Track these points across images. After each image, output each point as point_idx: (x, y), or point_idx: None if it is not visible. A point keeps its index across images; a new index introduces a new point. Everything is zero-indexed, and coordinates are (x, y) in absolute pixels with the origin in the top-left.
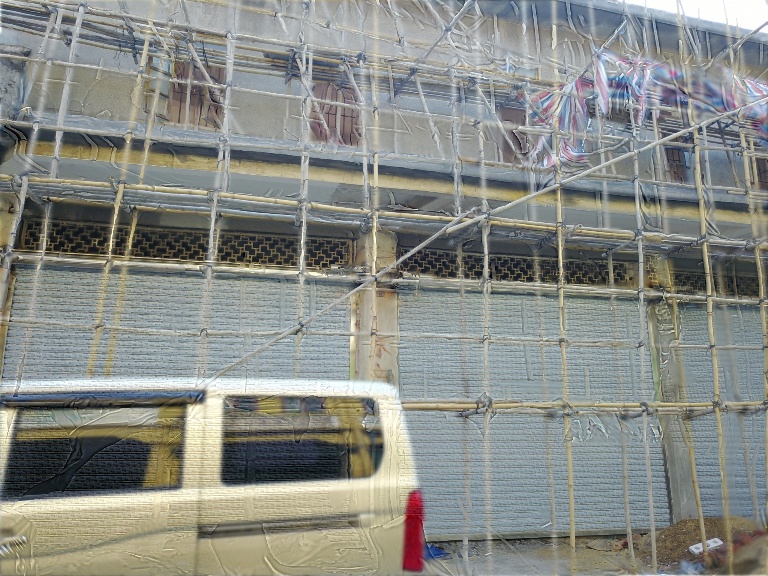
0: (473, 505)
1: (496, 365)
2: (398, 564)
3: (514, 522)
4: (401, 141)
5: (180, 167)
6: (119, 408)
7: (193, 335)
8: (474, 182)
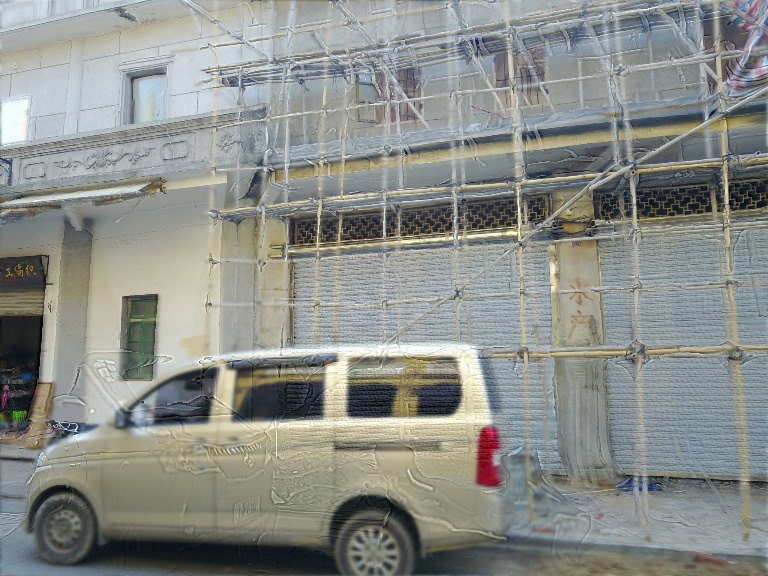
0: (691, 445)
1: (717, 303)
2: (516, 484)
3: (734, 464)
4: (586, 88)
5: (375, 168)
6: (332, 362)
7: (416, 297)
8: (644, 123)
